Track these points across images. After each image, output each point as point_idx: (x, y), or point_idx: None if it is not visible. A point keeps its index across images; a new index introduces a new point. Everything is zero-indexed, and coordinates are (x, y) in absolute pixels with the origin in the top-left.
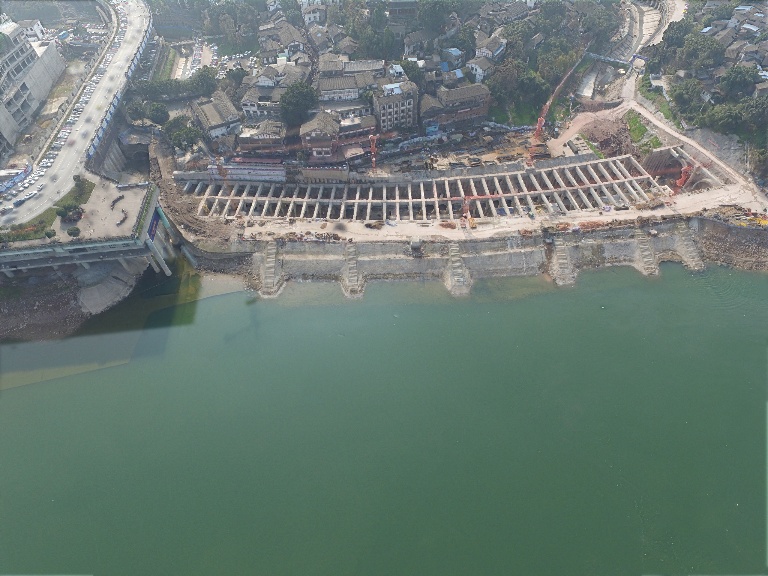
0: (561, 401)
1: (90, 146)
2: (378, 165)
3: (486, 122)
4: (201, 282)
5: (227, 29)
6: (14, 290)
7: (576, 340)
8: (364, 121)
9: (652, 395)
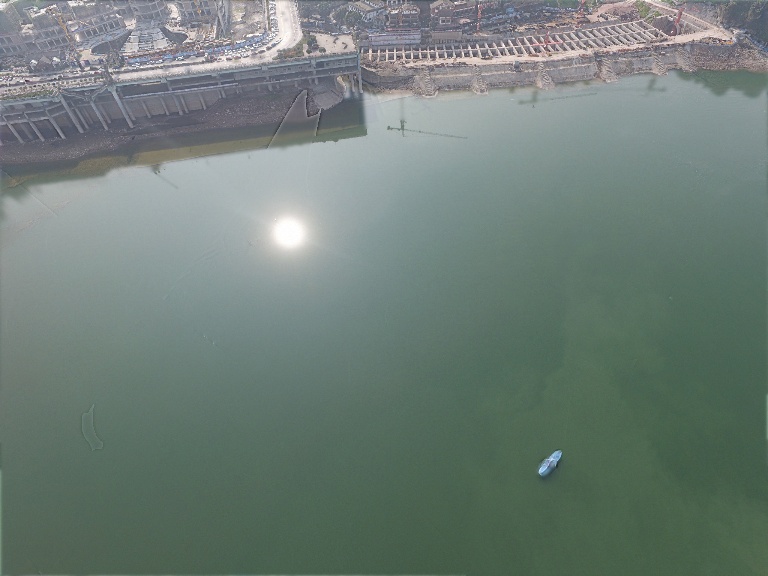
0: (621, 123)
1: (300, 20)
2: (479, 31)
3: (543, 7)
4: (384, 94)
5: None
6: (277, 95)
7: (623, 103)
8: (469, 2)
9: (672, 118)
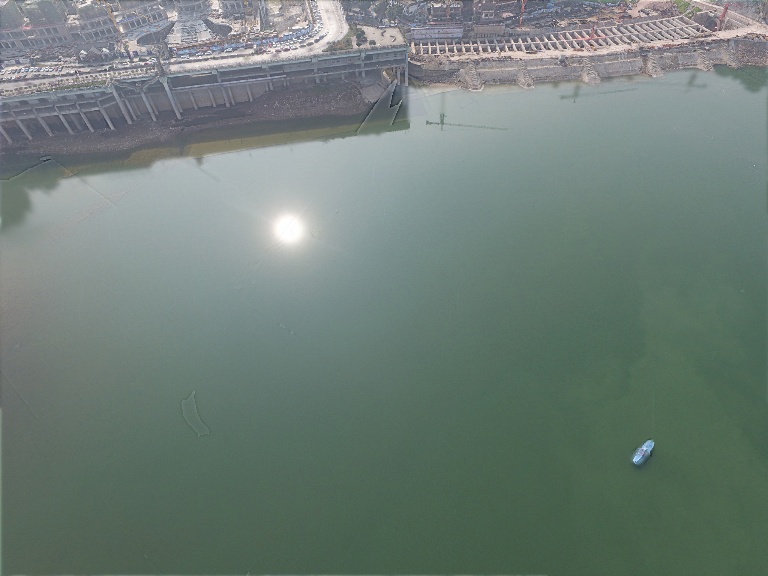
0: (672, 118)
1: None
2: (521, 25)
3: (583, 2)
4: (430, 87)
5: None
6: (325, 88)
7: (672, 98)
8: None
9: (723, 113)
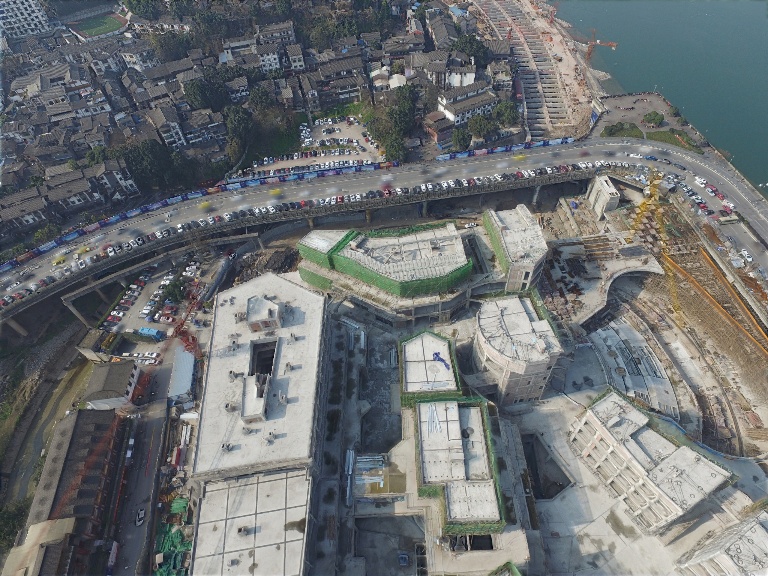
0: None
1: (557, 138)
2: None
3: None
4: None
5: (274, 122)
6: None
7: None
8: None
9: None
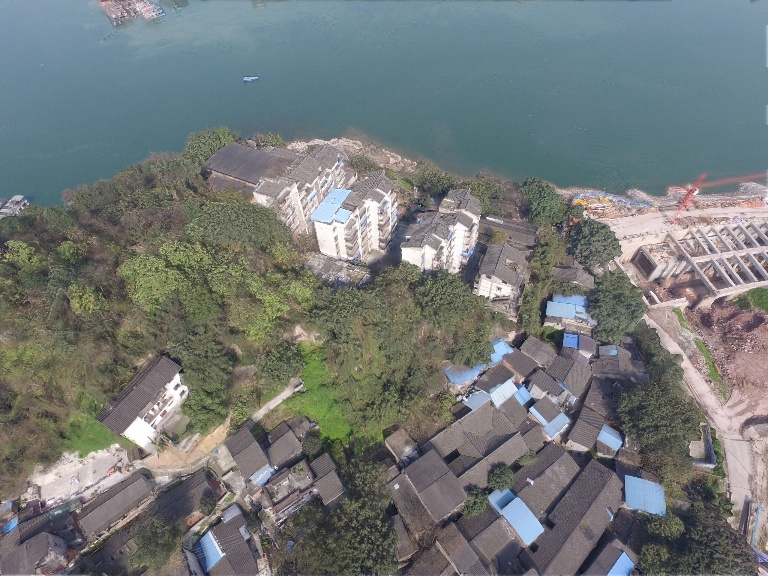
0: (733, 126)
1: None
2: None
3: None
4: None
5: None
6: None
7: (729, 153)
8: None
9: (676, 128)
